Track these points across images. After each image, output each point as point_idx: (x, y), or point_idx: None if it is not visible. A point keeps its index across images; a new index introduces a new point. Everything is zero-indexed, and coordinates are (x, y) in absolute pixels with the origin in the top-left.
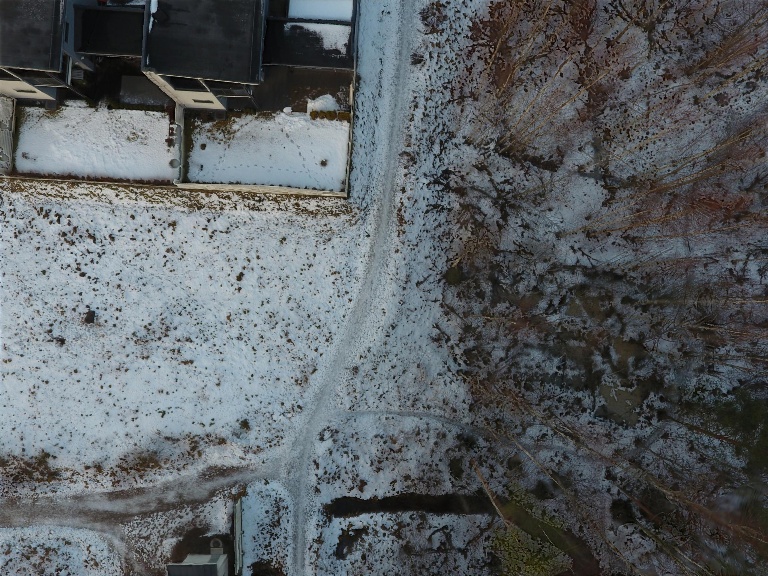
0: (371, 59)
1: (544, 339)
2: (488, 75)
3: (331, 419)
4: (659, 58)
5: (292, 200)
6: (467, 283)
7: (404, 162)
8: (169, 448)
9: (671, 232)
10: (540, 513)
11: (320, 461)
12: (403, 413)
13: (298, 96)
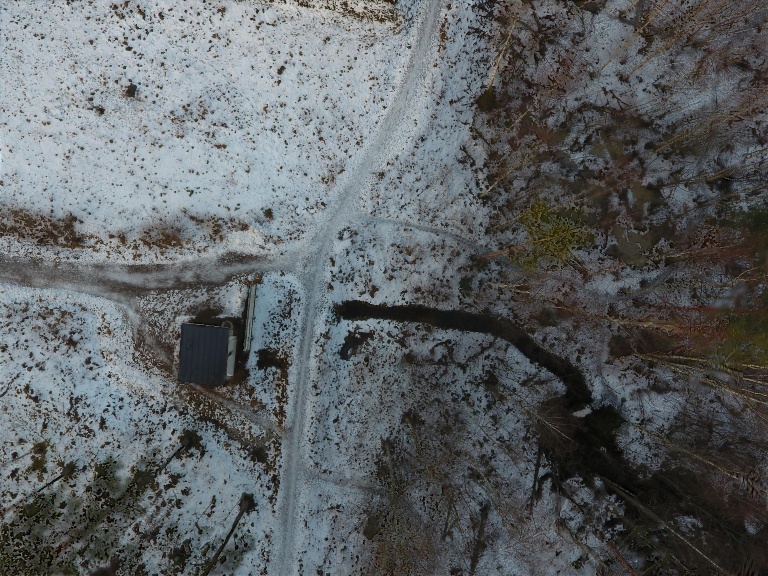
0: None
1: (566, 174)
2: None
3: (352, 220)
4: None
5: None
6: (498, 111)
7: None
8: (193, 228)
9: (701, 86)
10: (541, 339)
11: (337, 259)
12: (421, 227)
13: None
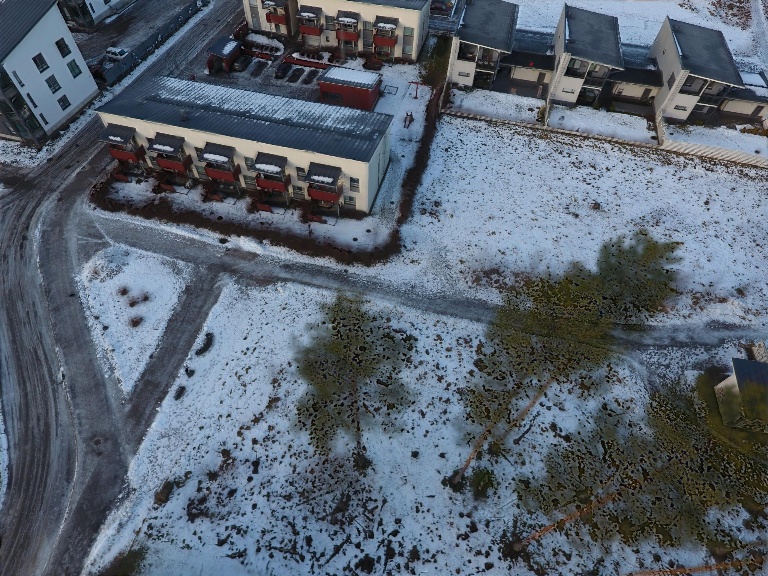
0: (765, 118)
1: None
2: None
3: None
4: None
5: (738, 167)
6: None
7: None
8: (674, 298)
9: None
10: None
11: None
12: None
13: (728, 123)
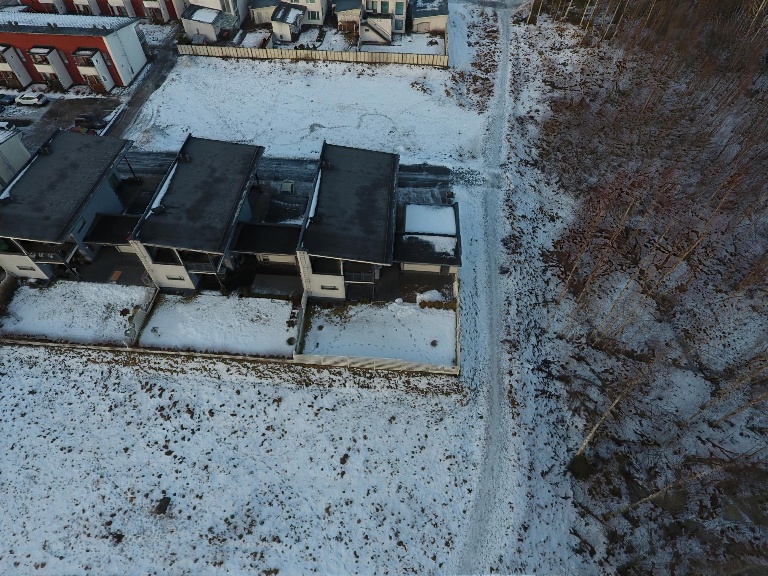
0: (467, 268)
1: (711, 553)
2: (564, 286)
3: None
4: (704, 278)
5: (403, 377)
6: (596, 477)
7: (507, 348)
8: None
9: None
10: None
11: None
12: None
13: (408, 291)
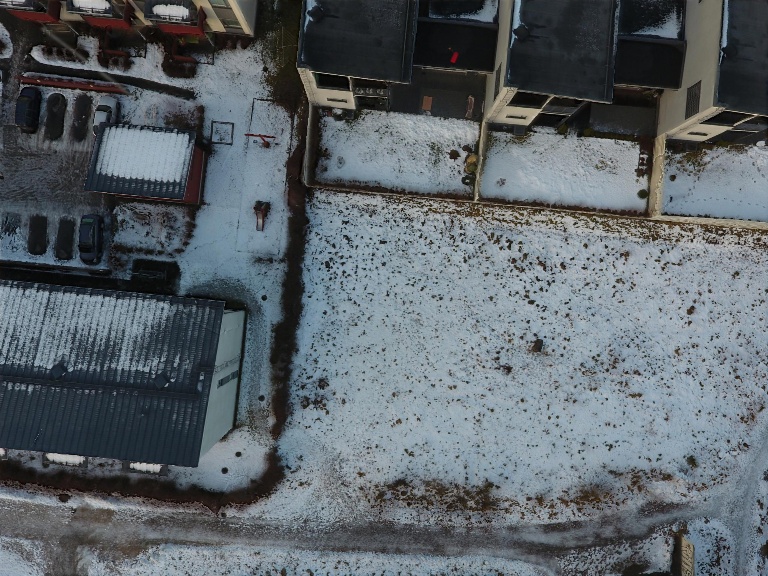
0: None
1: None
2: None
3: None
4: None
5: (755, 235)
6: None
7: None
8: (610, 482)
9: None
10: None
11: (765, 501)
12: None
13: None
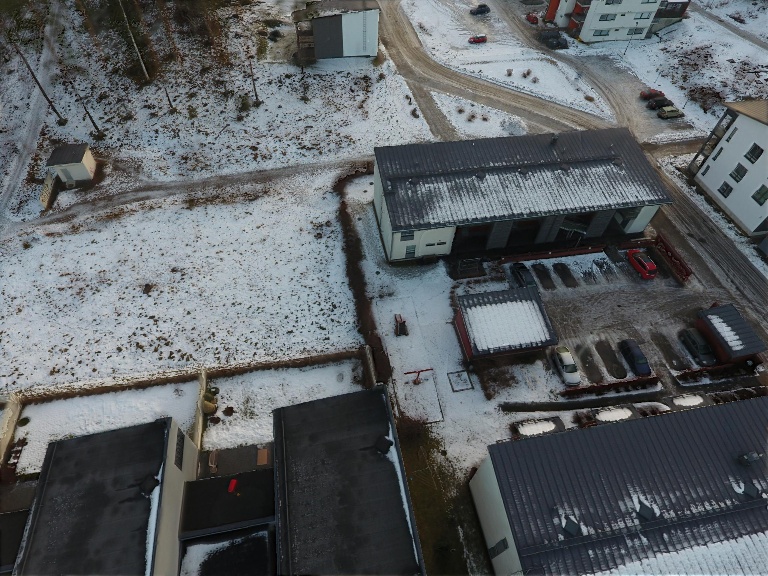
0: None
1: None
2: None
3: None
4: None
5: None
6: None
7: None
8: (96, 226)
9: None
10: None
11: None
12: None
13: None
